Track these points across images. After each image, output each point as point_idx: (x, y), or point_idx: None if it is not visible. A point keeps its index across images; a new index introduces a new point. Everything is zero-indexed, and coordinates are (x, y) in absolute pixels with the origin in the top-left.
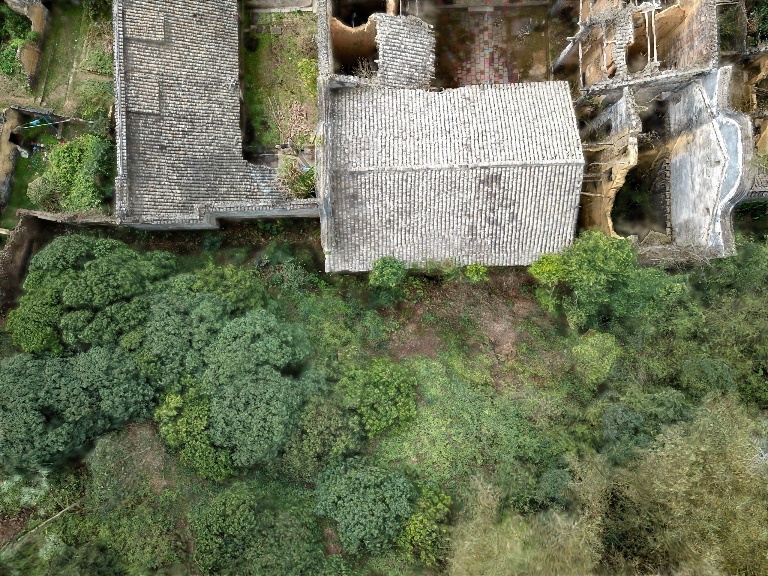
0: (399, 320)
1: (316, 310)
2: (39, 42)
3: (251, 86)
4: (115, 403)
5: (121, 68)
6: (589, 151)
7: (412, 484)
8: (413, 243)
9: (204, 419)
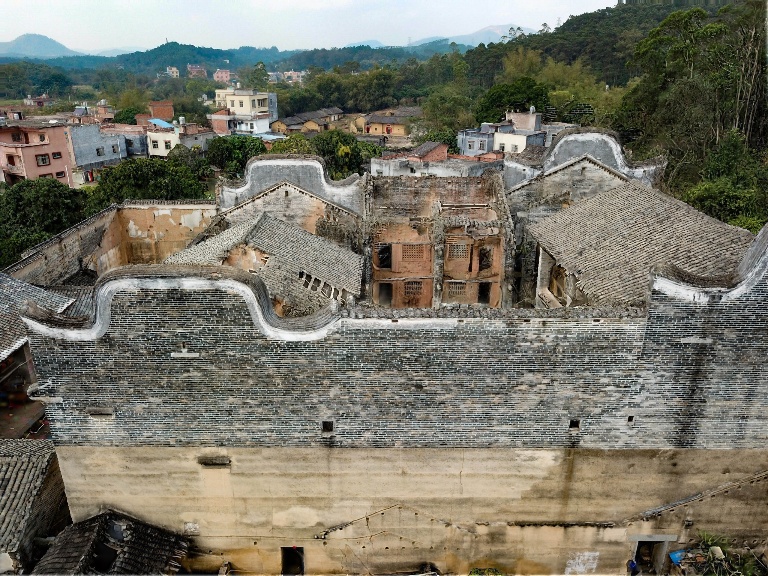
0: None
1: None
2: None
3: None
4: None
5: None
6: None
7: None
8: None
9: None
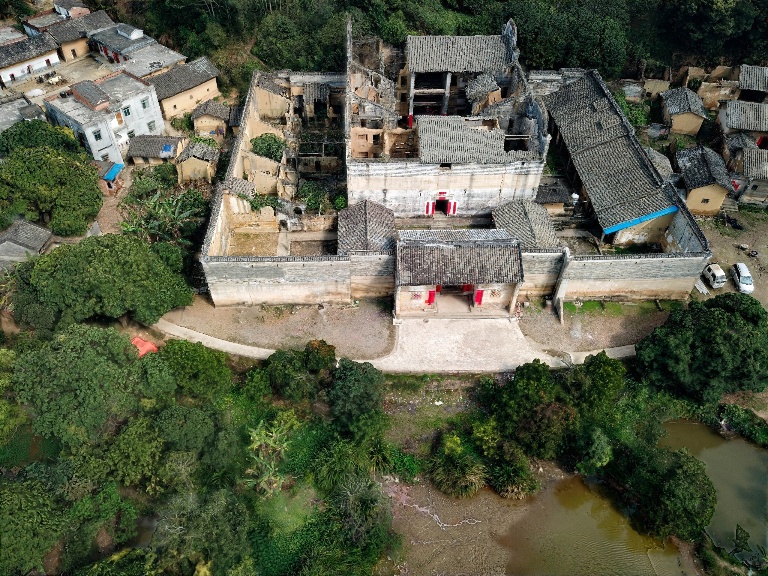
0: None
1: None
2: None
3: None
4: (573, 5)
5: None
6: None
7: (460, 3)
8: None
9: (539, 5)
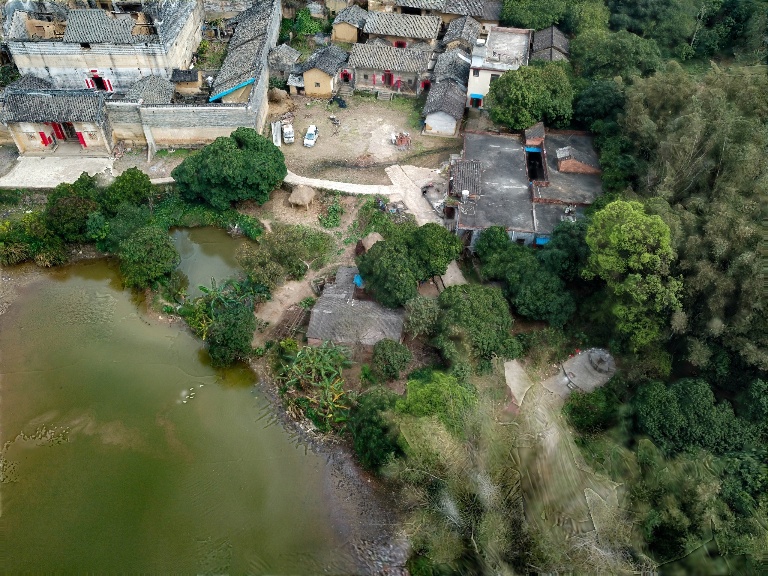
0: None
1: None
2: None
3: None
4: None
5: None
6: None
7: None
8: None
9: None
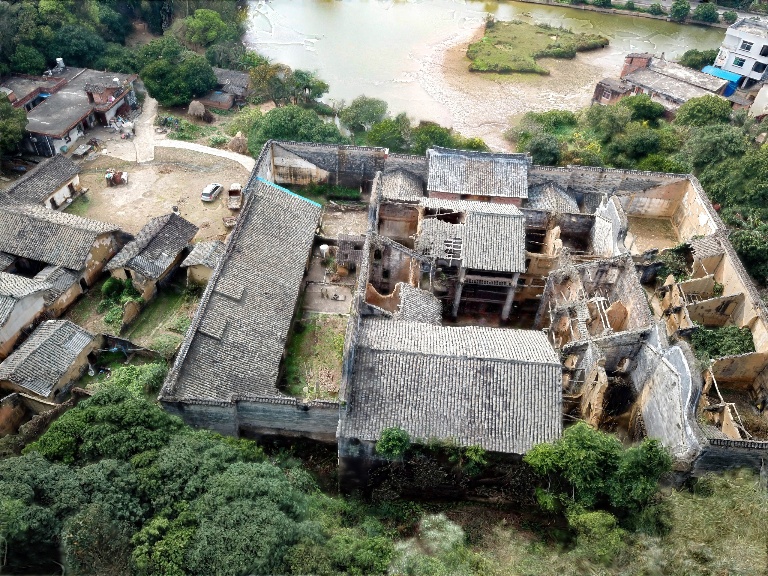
0: (397, 527)
1: (315, 503)
2: (142, 306)
3: (292, 354)
4: (103, 507)
5: (204, 305)
6: (570, 397)
7: None
8: (418, 419)
9: (186, 538)
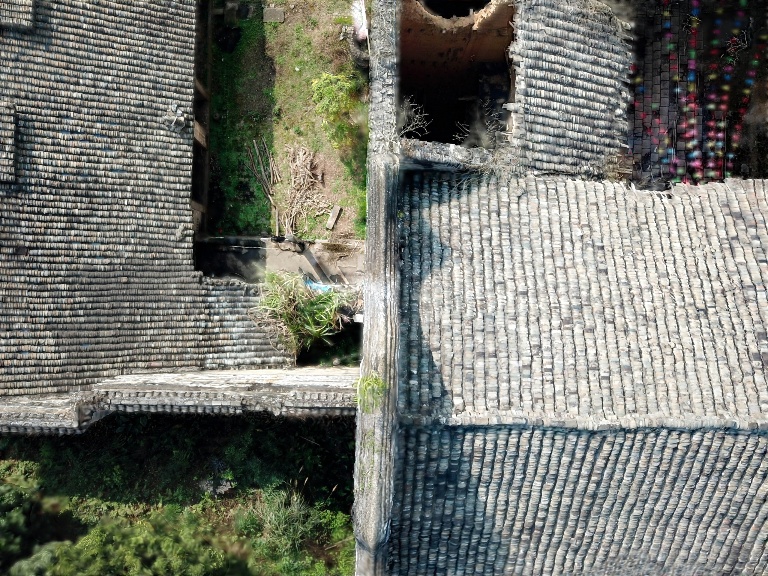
0: None
1: None
2: None
3: (222, 117)
4: None
5: None
6: None
7: None
8: (581, 571)
9: None
